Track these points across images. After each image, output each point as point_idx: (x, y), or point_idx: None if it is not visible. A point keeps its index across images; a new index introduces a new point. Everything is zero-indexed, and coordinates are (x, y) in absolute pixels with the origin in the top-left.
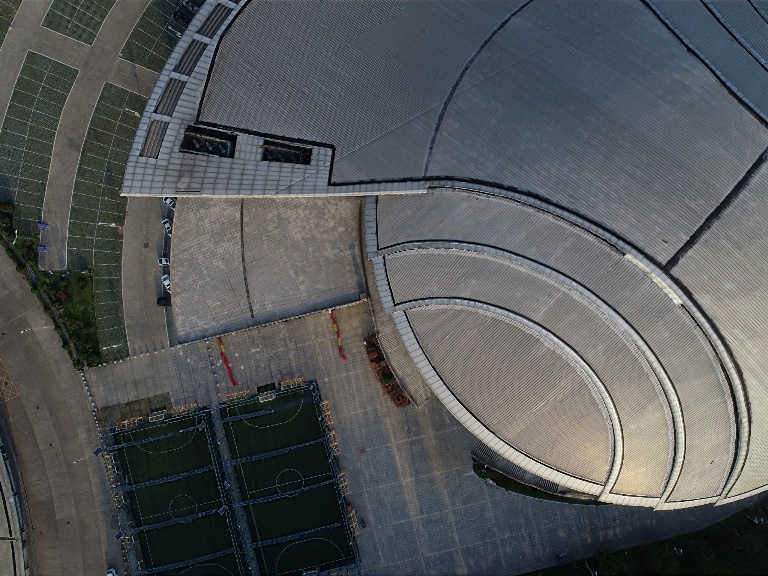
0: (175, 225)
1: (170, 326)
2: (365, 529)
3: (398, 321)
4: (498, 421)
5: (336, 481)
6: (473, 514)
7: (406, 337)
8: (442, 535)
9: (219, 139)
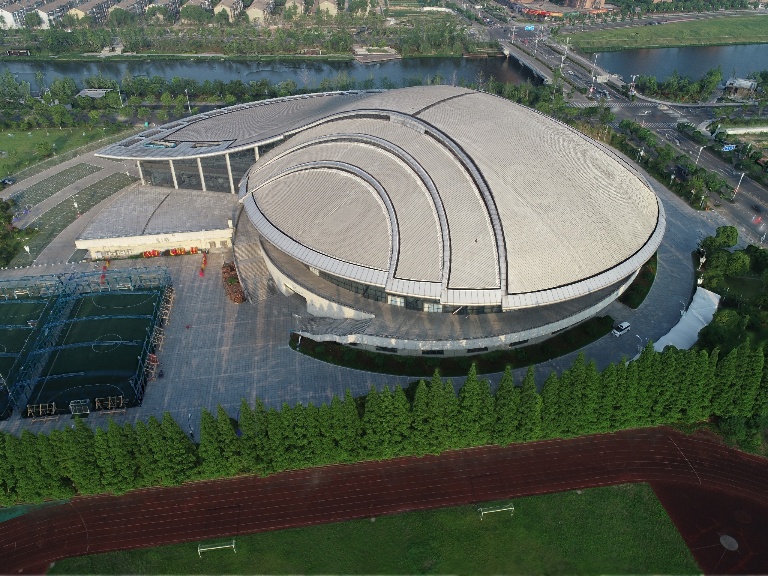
0: (118, 199)
1: (75, 254)
2: (160, 381)
3: (246, 201)
4: (302, 231)
5: (152, 317)
6: (278, 376)
7: (249, 206)
8: (239, 390)
9: (170, 143)
